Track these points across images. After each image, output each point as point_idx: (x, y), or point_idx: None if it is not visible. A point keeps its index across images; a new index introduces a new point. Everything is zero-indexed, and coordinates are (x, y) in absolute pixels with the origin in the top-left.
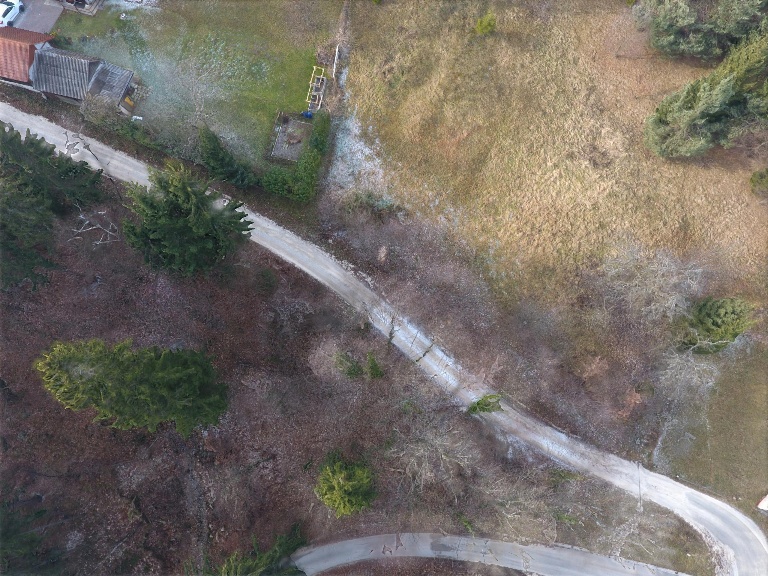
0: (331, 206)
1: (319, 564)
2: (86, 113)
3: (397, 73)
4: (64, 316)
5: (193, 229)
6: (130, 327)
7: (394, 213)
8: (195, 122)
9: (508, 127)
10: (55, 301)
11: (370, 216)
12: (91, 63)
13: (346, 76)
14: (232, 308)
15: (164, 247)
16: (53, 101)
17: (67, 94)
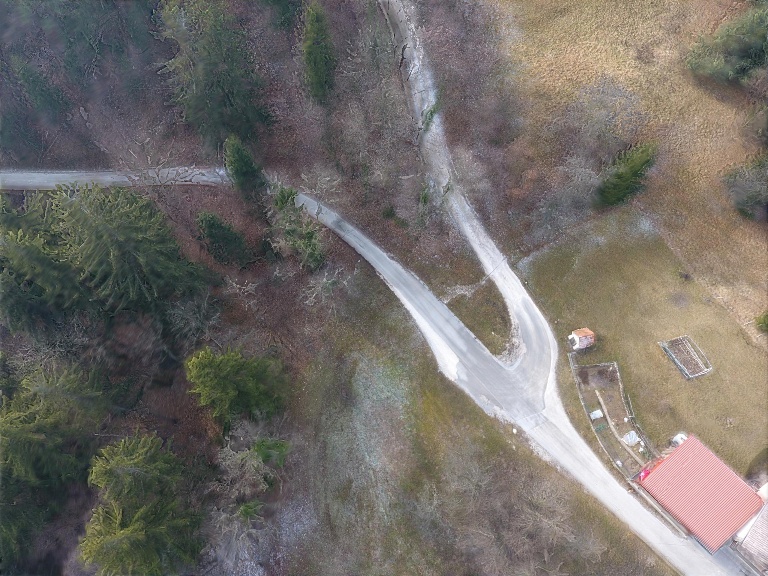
0: None
1: None
2: None
3: None
4: None
5: None
6: None
7: (464, 8)
8: None
9: None
10: None
11: None
12: None
13: None
14: (326, 6)
15: None
16: None
17: None
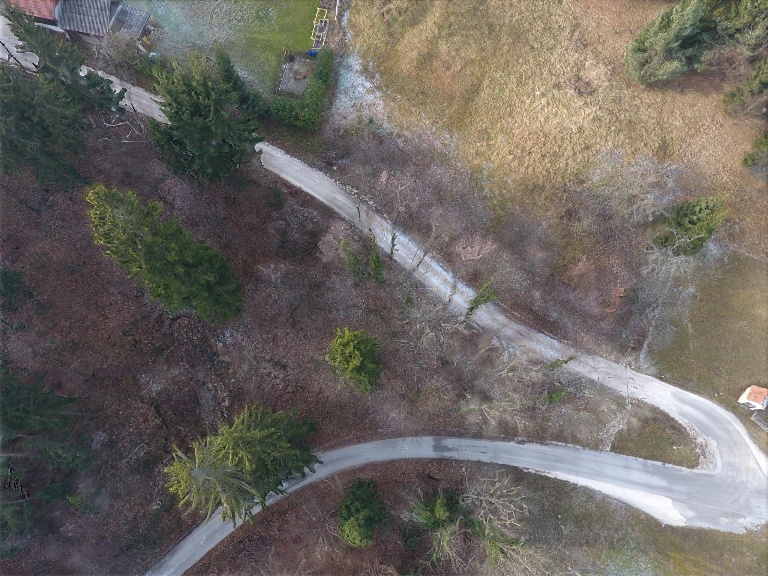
0: (335, 135)
1: (328, 467)
2: (108, 47)
3: (395, 14)
4: (88, 233)
5: (212, 128)
6: None
7: (394, 140)
8: (211, 45)
9: (499, 60)
10: (80, 219)
11: (372, 142)
12: (112, 3)
13: (347, 18)
14: (244, 228)
15: (185, 149)
16: (76, 41)
17: (90, 31)
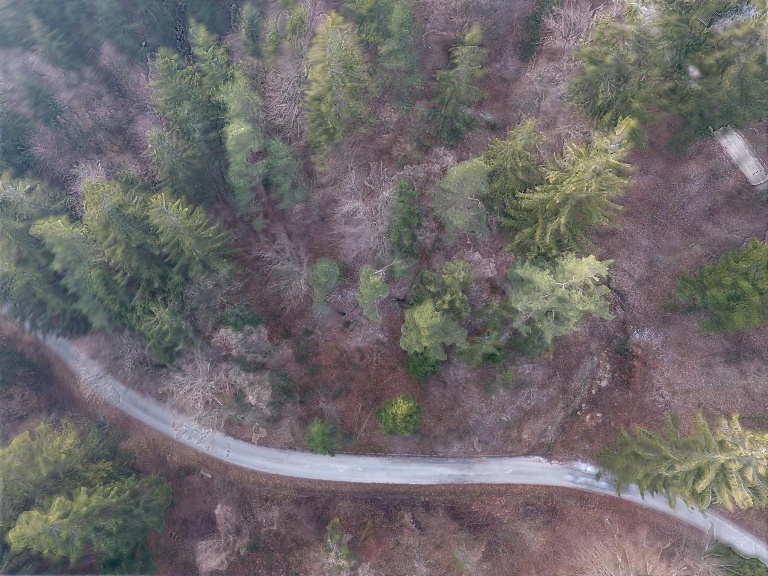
0: None
1: (654, 502)
2: None
3: None
4: None
5: None
6: (634, 220)
7: None
8: None
9: None
10: None
11: None
12: None
13: None
14: None
15: None
16: None
17: None
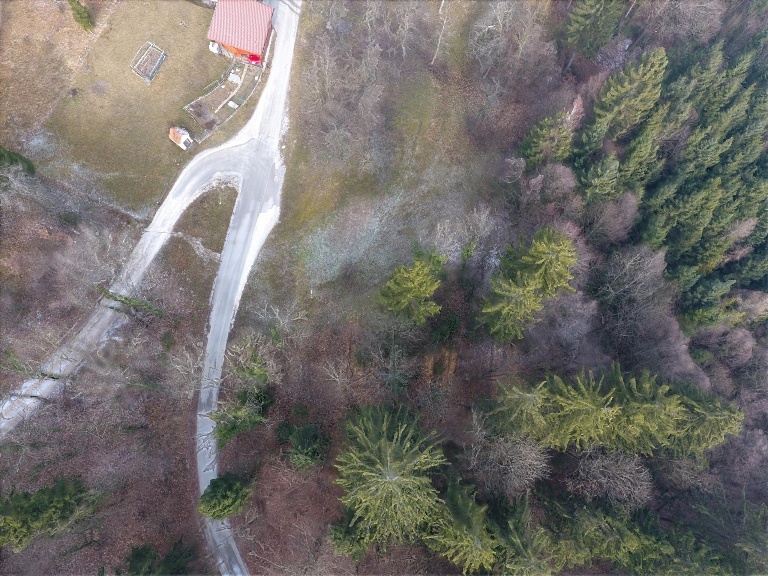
0: None
1: None
2: None
3: None
4: None
5: None
6: None
7: None
8: None
9: None
10: None
11: None
12: None
13: None
14: None
15: None
16: None
17: None
